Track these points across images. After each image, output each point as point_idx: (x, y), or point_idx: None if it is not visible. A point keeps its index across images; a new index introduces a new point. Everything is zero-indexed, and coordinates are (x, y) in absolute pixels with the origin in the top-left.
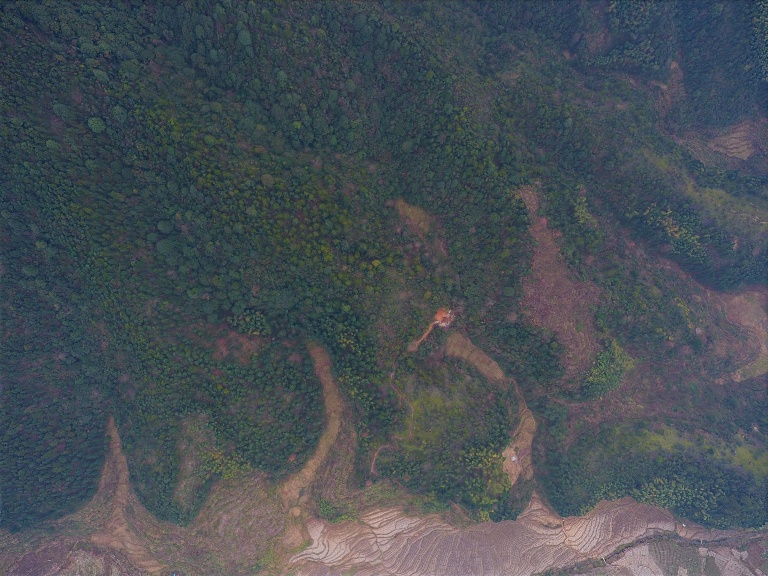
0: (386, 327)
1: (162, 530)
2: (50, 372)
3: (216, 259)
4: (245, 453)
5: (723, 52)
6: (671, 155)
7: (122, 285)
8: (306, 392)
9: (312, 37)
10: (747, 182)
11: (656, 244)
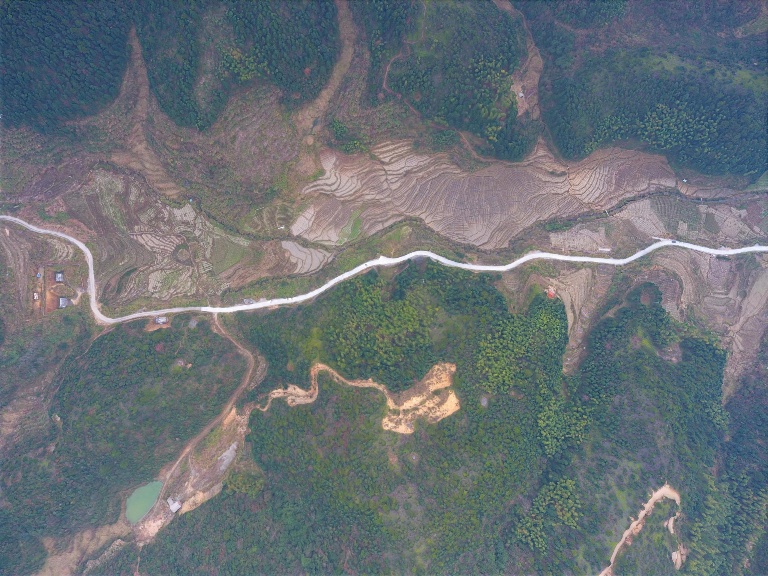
0: None
1: (181, 138)
2: None
3: None
4: (263, 47)
5: None
6: None
7: None
8: (322, 1)
9: None
10: None
11: None
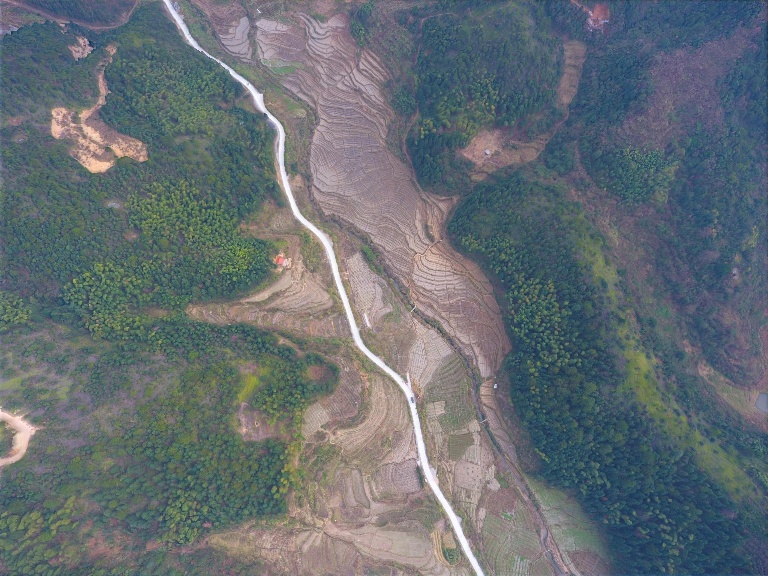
0: None
1: None
2: None
3: None
4: None
5: None
6: None
7: None
8: None
9: None
10: None
11: None
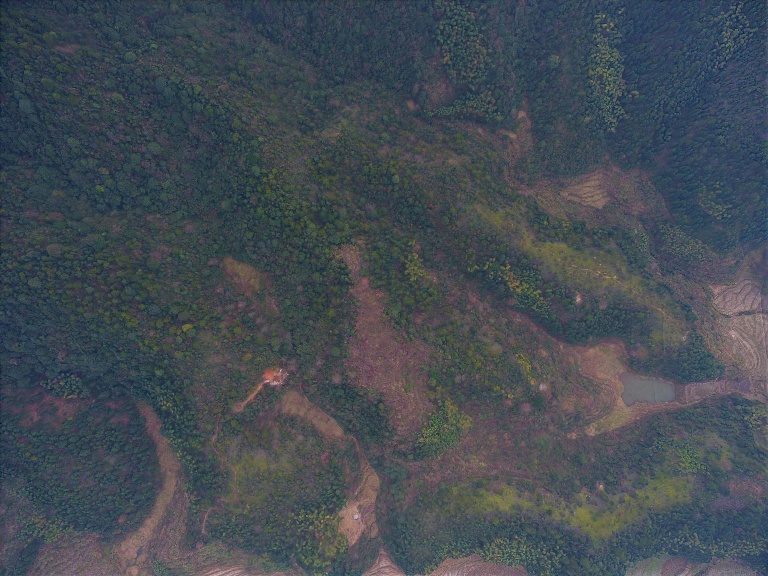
0: (204, 390)
1: None
2: None
3: (15, 326)
4: (65, 517)
5: (563, 104)
6: (510, 209)
7: None
8: (132, 453)
9: (106, 102)
10: (594, 234)
11: (502, 297)
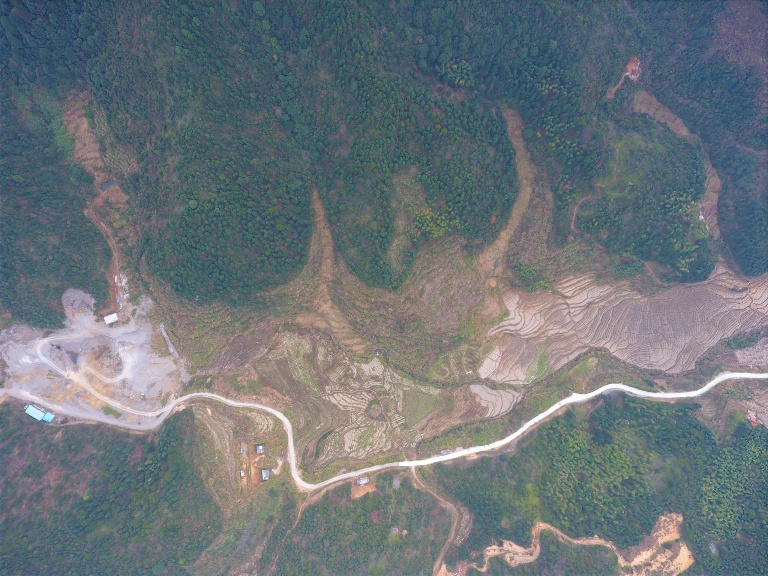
0: (590, 66)
1: (371, 298)
2: (267, 130)
3: None
4: (456, 205)
5: None
6: None
7: (357, 7)
8: (505, 149)
9: None
10: None
11: None
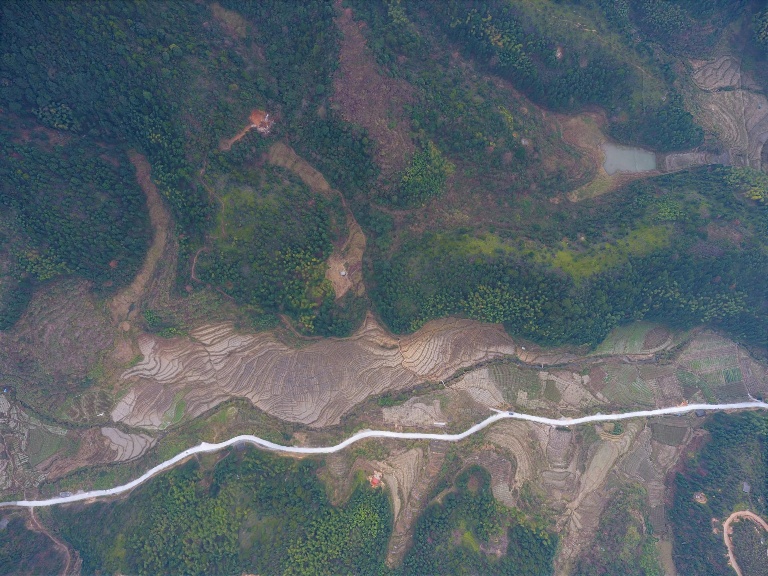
0: (191, 118)
1: None
2: None
3: (6, 35)
4: (57, 250)
5: None
6: None
7: None
8: (123, 195)
9: None
10: None
11: (485, 58)
